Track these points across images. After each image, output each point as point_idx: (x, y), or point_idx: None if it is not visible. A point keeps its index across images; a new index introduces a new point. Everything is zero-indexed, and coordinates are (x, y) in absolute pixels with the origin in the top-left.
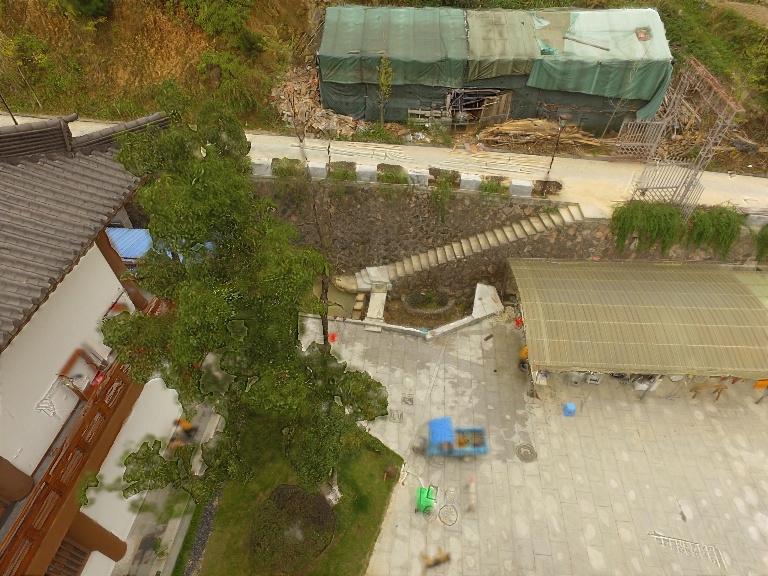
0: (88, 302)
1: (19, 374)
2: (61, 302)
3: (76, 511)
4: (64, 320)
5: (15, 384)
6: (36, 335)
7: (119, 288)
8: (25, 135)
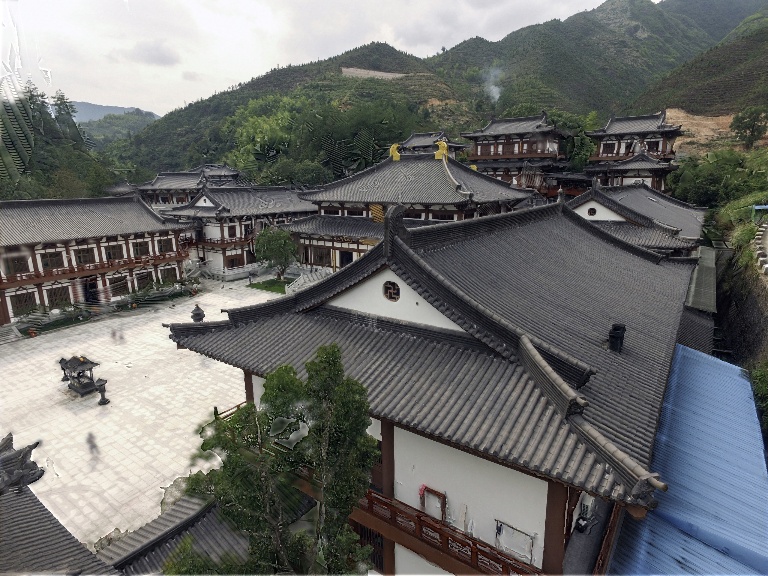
0: (502, 501)
1: (433, 464)
2: (484, 474)
3: (366, 525)
4: (477, 484)
5: (429, 465)
6: (456, 465)
7: (538, 534)
8: (554, 386)
